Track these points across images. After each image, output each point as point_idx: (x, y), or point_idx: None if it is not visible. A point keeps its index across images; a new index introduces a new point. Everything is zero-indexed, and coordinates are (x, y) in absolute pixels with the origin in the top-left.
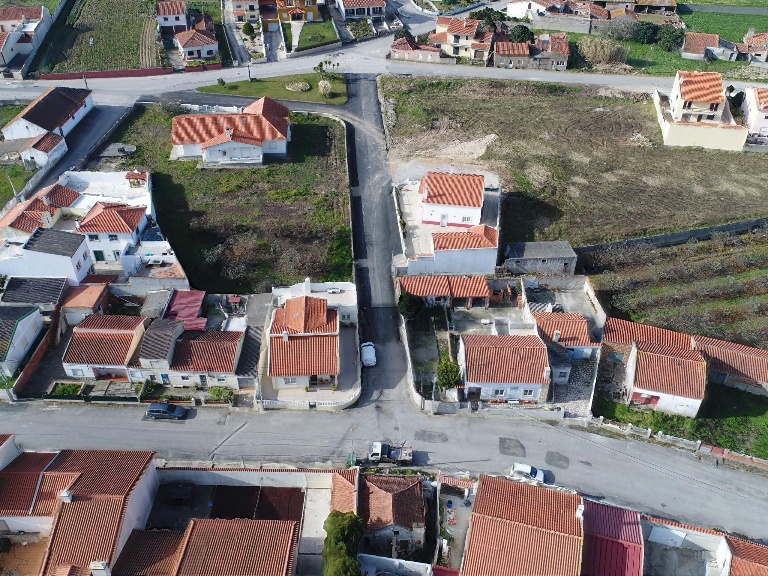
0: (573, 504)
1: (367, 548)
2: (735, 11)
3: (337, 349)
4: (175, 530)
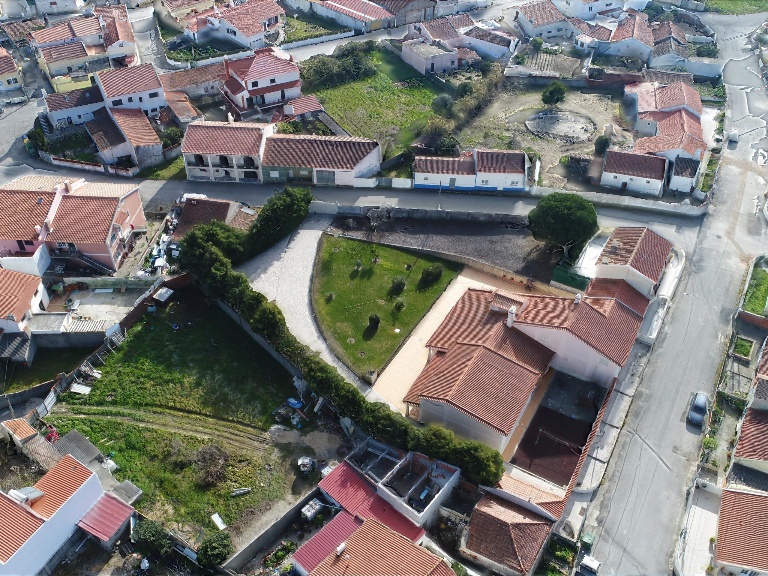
0: None
1: (475, 501)
2: None
3: (757, 568)
4: (557, 389)
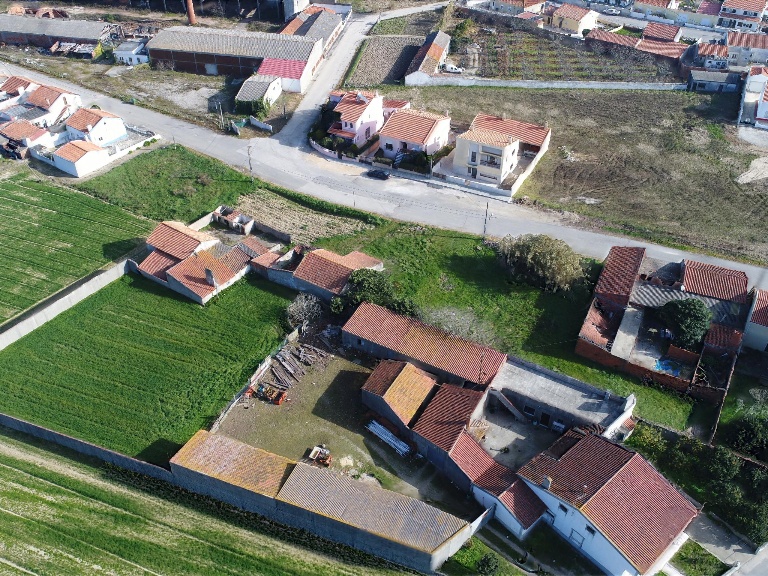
0: (727, 3)
1: None
2: (34, 431)
3: None
4: None
